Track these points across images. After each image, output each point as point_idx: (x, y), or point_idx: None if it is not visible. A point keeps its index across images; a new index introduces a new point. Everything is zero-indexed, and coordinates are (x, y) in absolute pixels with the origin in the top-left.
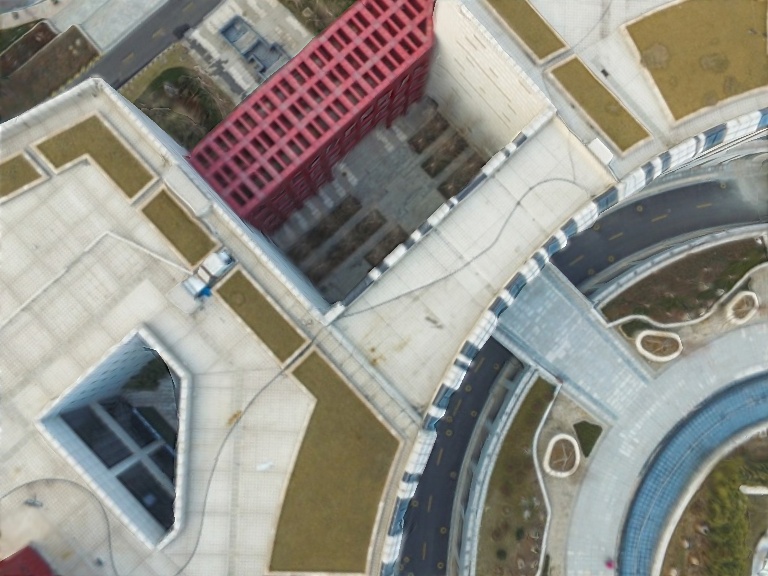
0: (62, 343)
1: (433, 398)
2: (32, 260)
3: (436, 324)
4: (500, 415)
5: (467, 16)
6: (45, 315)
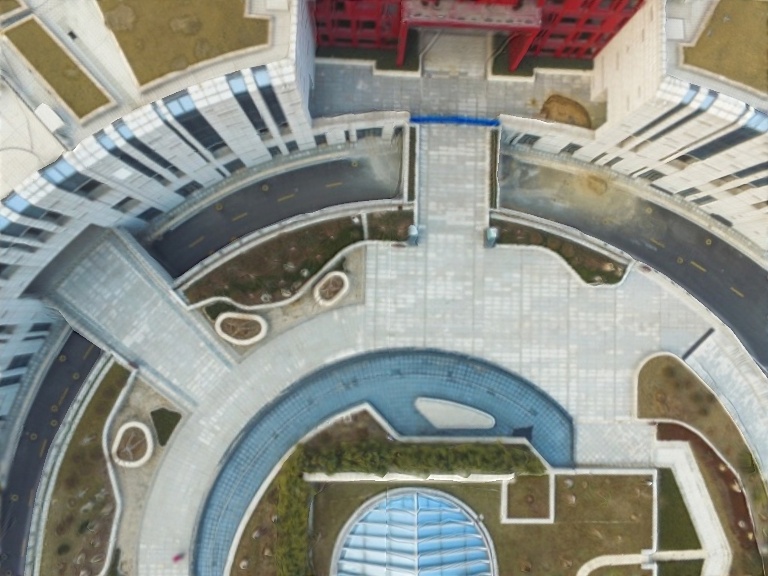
0: None
1: None
2: None
3: None
4: (71, 403)
5: None
6: None
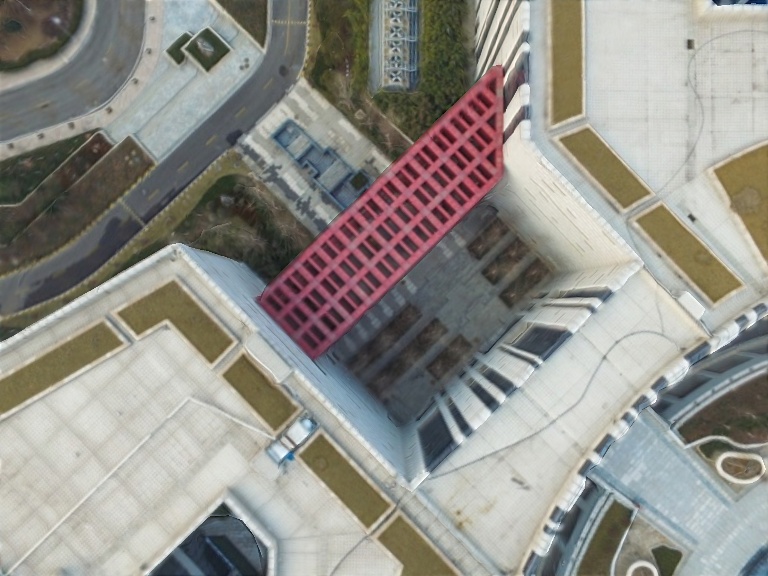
0: (148, 509)
1: (522, 564)
2: (116, 427)
3: (522, 485)
4: (575, 540)
5: (547, 168)
6: (130, 482)
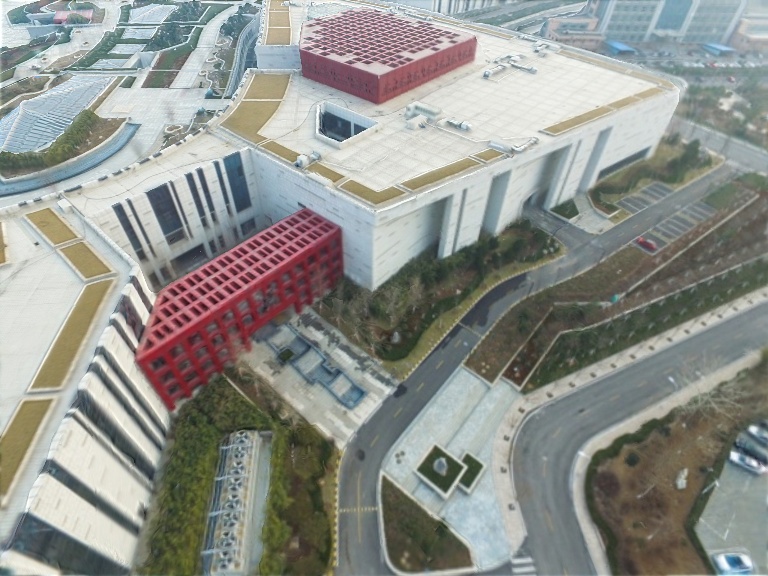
0: None
1: None
2: None
3: None
4: None
5: (127, 254)
6: None
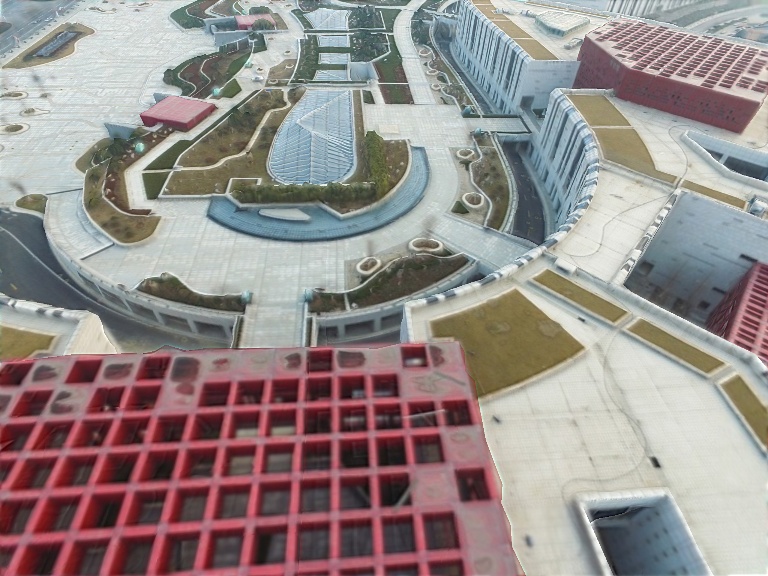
0: None
1: None
2: None
3: (615, 196)
4: None
5: None
6: None
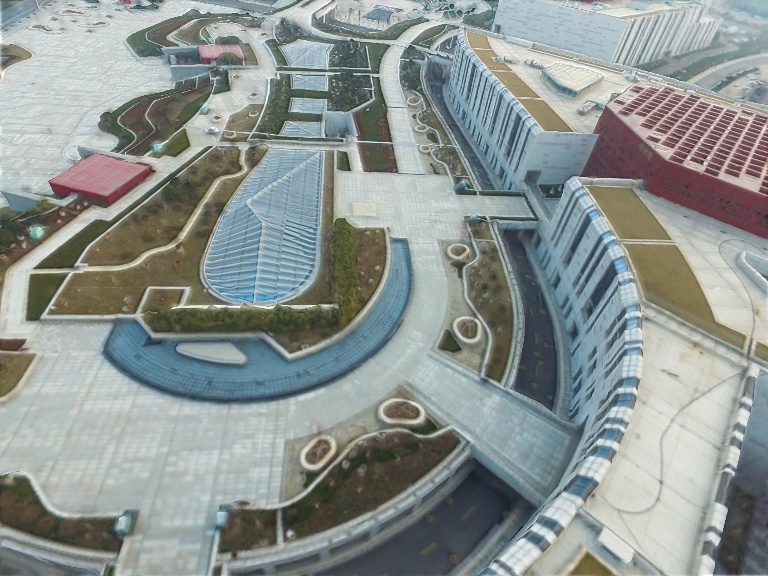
0: None
1: None
2: None
3: (668, 372)
4: None
5: None
6: None
